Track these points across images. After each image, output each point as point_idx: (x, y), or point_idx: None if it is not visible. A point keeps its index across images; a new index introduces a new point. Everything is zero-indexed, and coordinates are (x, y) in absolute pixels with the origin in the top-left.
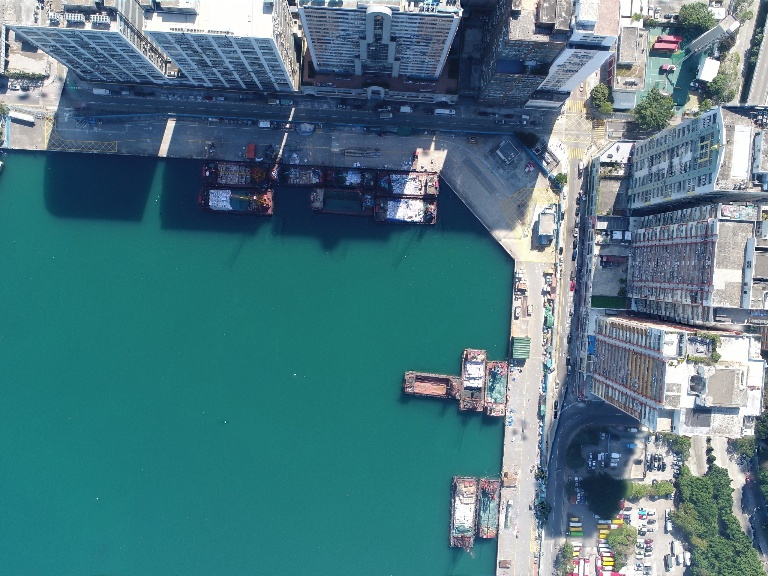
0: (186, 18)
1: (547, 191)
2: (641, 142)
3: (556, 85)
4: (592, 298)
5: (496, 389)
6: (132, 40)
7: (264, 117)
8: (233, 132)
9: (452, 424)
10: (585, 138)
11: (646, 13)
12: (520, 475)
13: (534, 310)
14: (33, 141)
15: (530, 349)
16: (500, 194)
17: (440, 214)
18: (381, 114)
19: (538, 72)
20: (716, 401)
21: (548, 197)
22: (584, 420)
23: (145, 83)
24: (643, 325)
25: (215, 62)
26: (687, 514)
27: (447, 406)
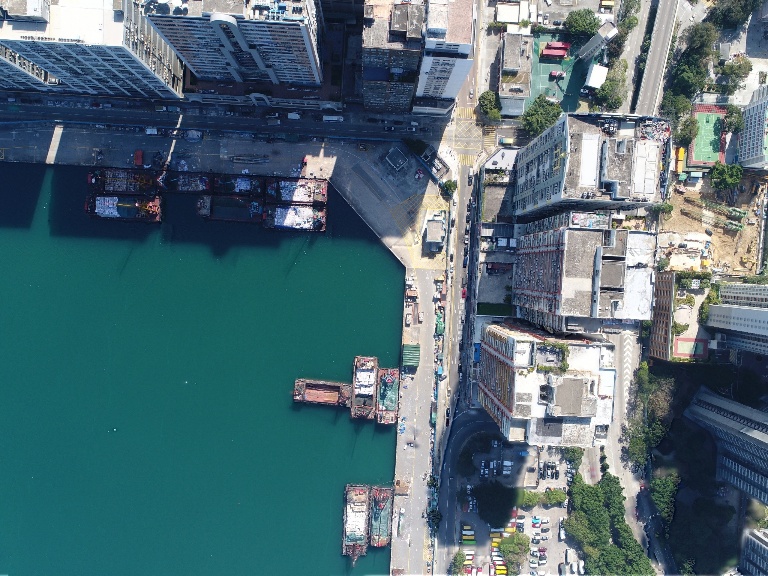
0: (36, 26)
1: (437, 198)
2: (522, 149)
3: (437, 92)
4: (478, 305)
5: (388, 397)
6: None
7: (152, 124)
8: (121, 139)
9: (345, 432)
10: (475, 145)
11: (534, 19)
12: (412, 483)
13: (425, 317)
14: None
15: (422, 356)
16: (390, 201)
17: (331, 221)
18: (268, 121)
19: (405, 79)
20: (564, 411)
21: (438, 204)
22: (476, 428)
23: (30, 90)
24: (506, 333)
25: (83, 70)
26: (578, 522)
27: (339, 414)
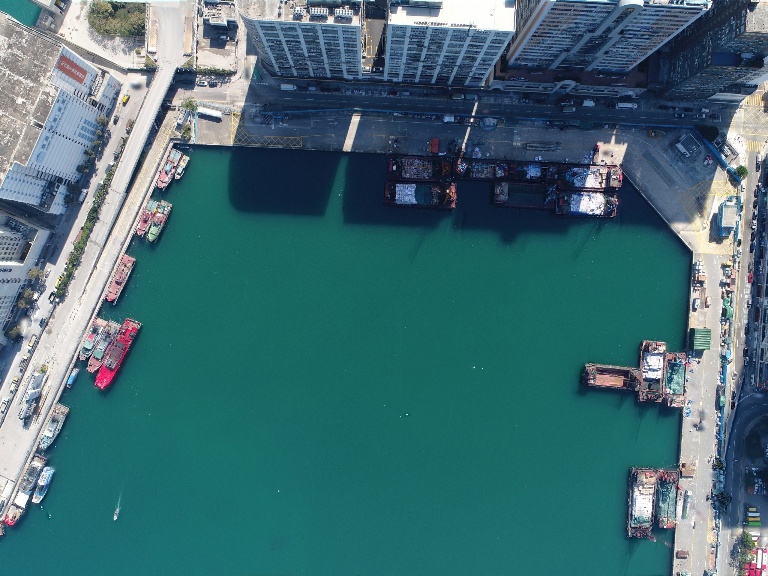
0: (430, 12)
1: (725, 184)
2: None
3: (749, 78)
4: None
5: (674, 380)
6: None
7: (447, 112)
8: (417, 127)
9: (629, 415)
10: (763, 131)
11: None
12: (697, 466)
13: (712, 302)
14: (220, 137)
15: None
16: (679, 187)
17: (618, 207)
18: (564, 108)
19: (753, 64)
20: None
21: (726, 190)
22: (761, 411)
23: (334, 78)
24: None
25: (430, 56)
26: None
27: (624, 398)
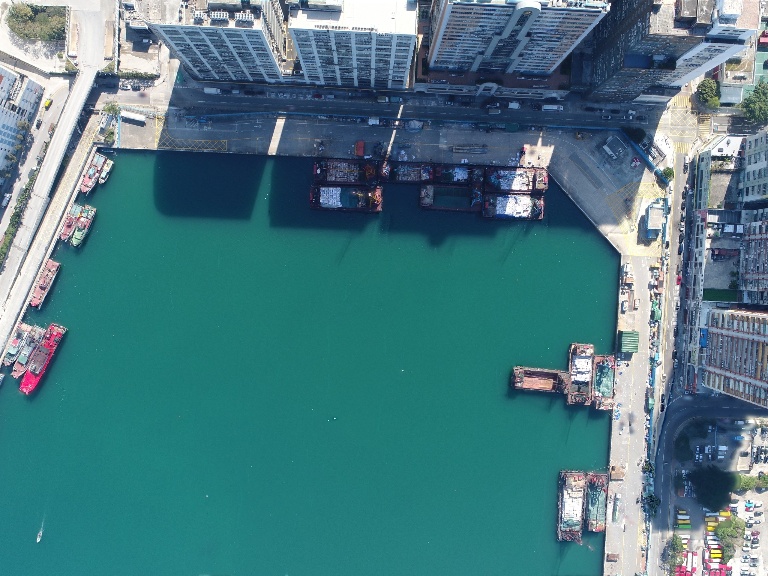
0: (331, 15)
1: (653, 186)
2: (755, 136)
3: (670, 80)
4: (703, 291)
5: (603, 383)
6: (267, 38)
7: (373, 114)
8: (342, 130)
9: (559, 418)
10: (690, 133)
11: None
12: (627, 469)
13: (641, 304)
14: (144, 140)
15: (637, 343)
16: (606, 189)
17: (546, 209)
18: (490, 110)
19: (665, 66)
20: None
21: (654, 191)
22: (691, 413)
23: (257, 82)
24: None
25: (342, 59)
26: None
27: (554, 400)
